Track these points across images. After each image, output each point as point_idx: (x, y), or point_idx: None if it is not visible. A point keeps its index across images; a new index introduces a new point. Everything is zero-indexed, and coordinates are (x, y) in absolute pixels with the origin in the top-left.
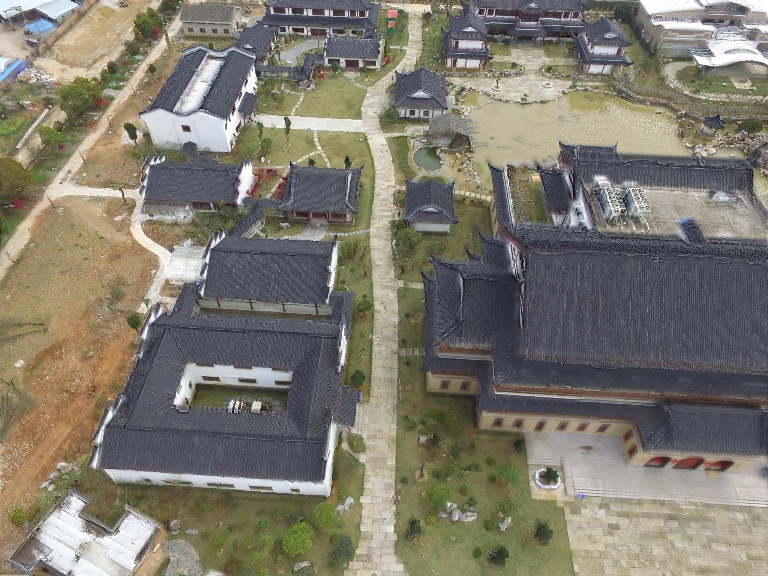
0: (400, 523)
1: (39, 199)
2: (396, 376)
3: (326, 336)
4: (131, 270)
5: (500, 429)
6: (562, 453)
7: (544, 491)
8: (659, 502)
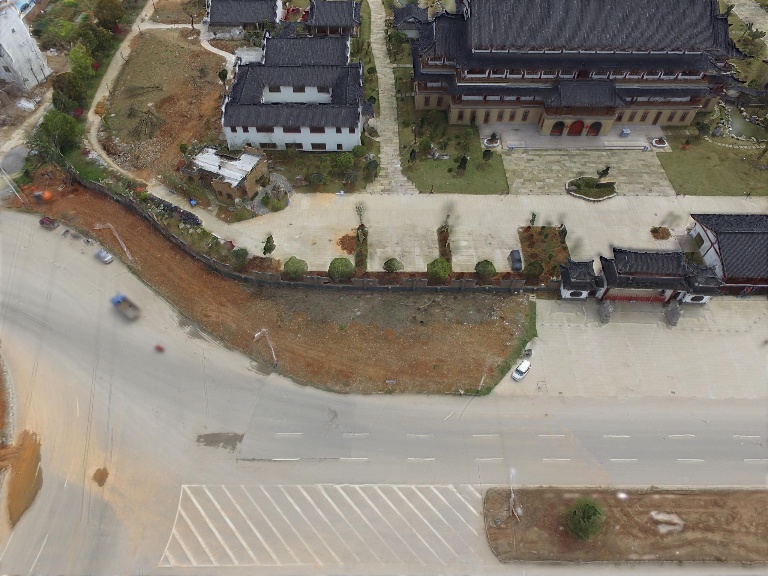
0: (404, 163)
1: (129, 31)
2: (396, 106)
3: (351, 67)
4: (209, 61)
5: (463, 123)
6: (501, 132)
7: (489, 148)
8: (558, 150)
